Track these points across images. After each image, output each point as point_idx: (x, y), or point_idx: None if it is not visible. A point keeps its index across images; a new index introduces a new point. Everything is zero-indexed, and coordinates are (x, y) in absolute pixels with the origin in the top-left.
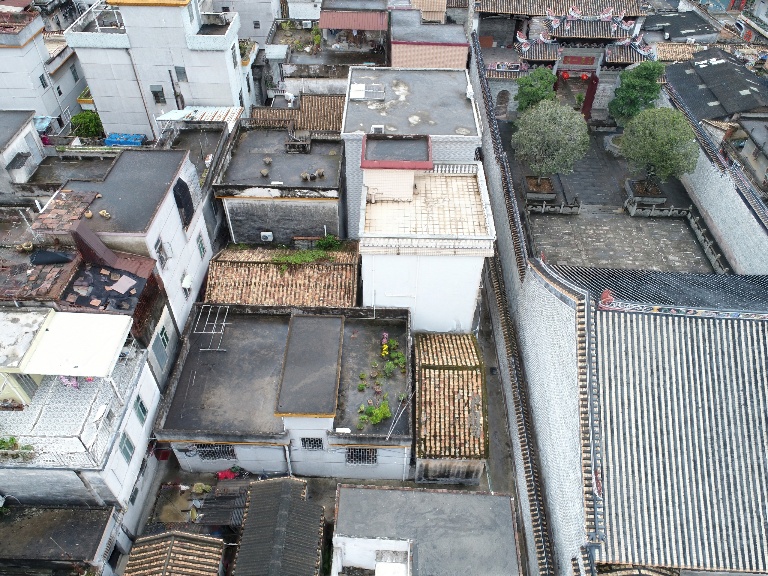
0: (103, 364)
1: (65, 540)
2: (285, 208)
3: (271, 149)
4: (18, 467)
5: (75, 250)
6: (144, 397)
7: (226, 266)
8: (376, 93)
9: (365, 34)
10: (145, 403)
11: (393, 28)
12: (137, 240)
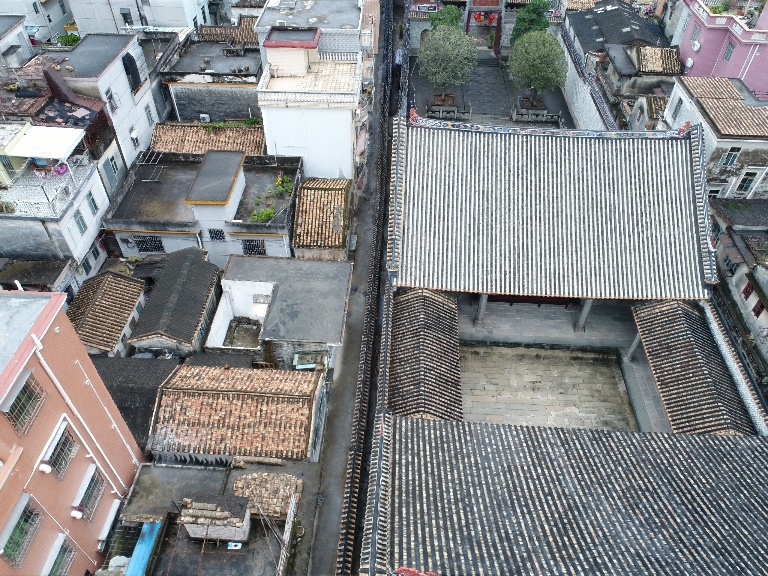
0: (62, 151)
1: (35, 275)
2: (217, 93)
3: (212, 55)
4: (3, 216)
5: (47, 91)
6: (95, 196)
7: (167, 128)
8: (288, 4)
9: None
10: (96, 201)
11: None
12: (92, 85)
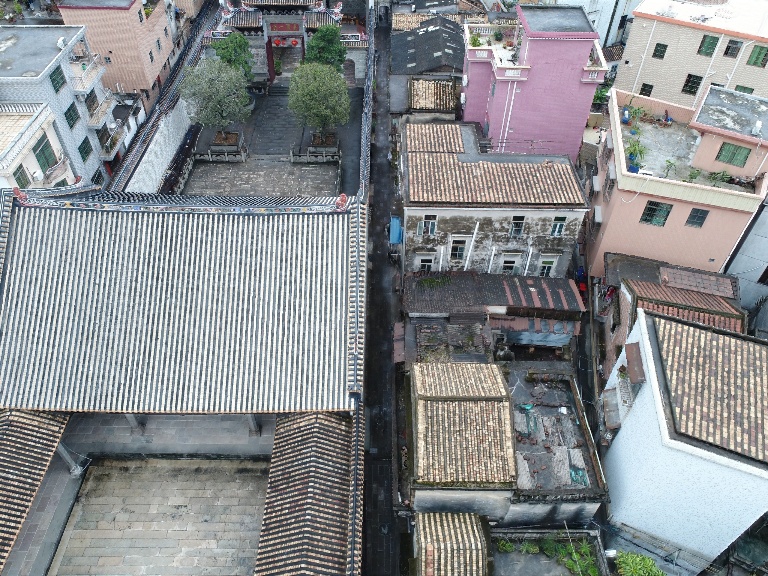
0: None
1: None
2: None
3: None
4: None
5: None
6: None
7: None
8: None
9: (54, 2)
10: None
11: None
12: None
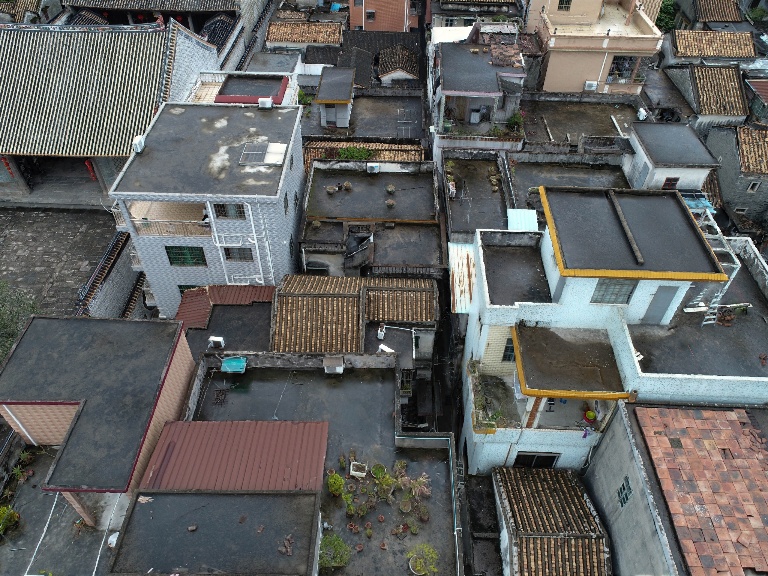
0: None
1: None
2: None
3: (394, 240)
4: None
5: None
6: None
7: None
8: (254, 151)
9: None
10: None
11: (160, 378)
12: None
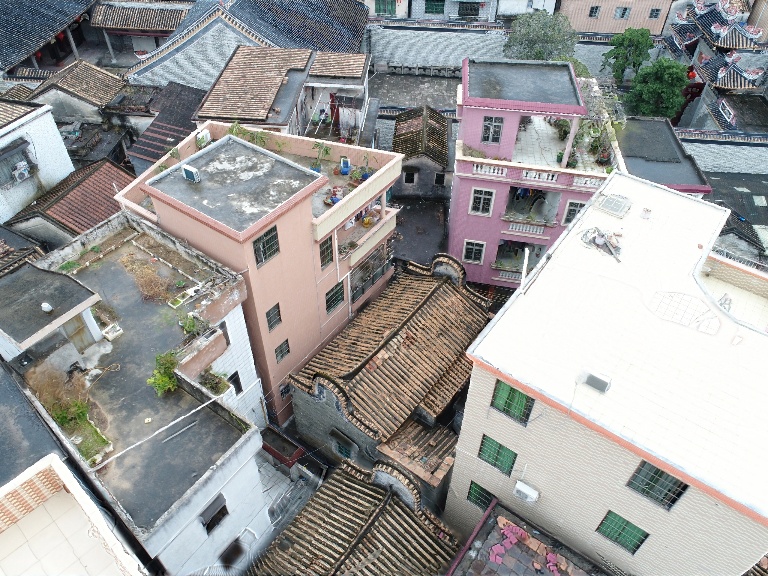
0: None
1: None
2: None
3: None
4: None
5: None
6: None
7: None
8: None
9: None
10: None
11: None
12: None
